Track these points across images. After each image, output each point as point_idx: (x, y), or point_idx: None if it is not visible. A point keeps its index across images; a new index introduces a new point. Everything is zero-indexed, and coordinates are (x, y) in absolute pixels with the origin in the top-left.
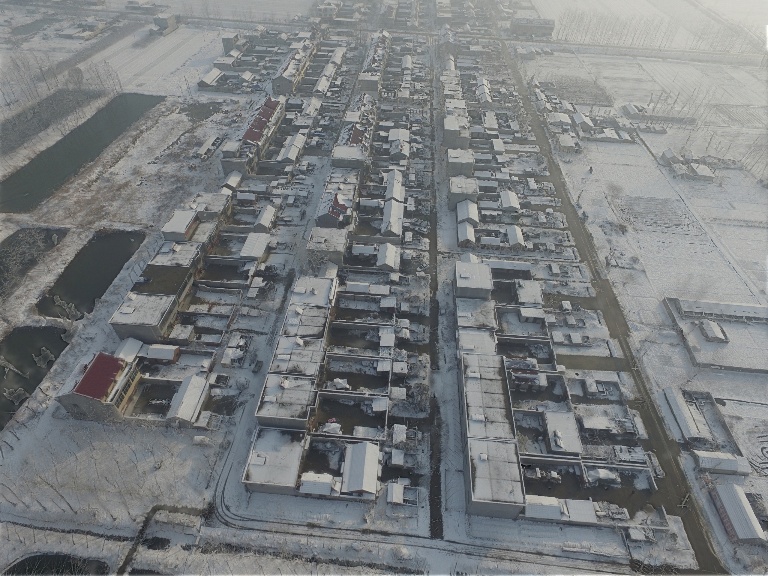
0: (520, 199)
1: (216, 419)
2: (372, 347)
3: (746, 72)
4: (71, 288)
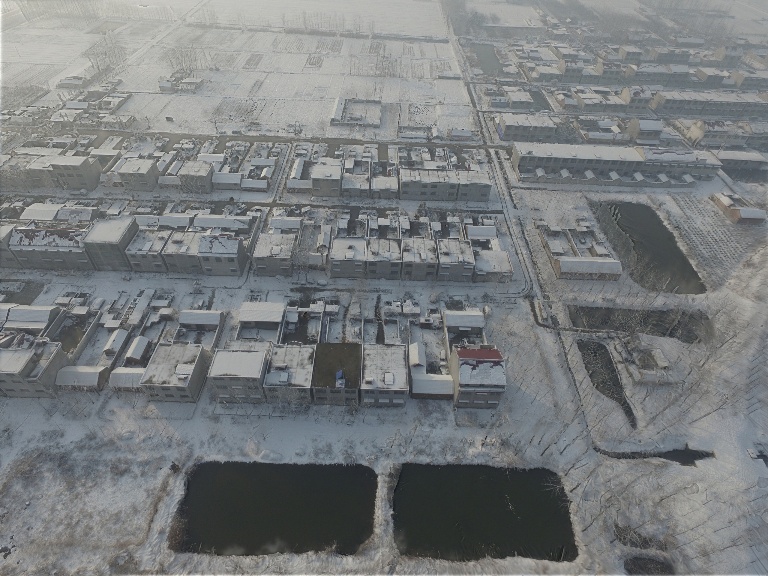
0: None
1: (470, 305)
2: (384, 235)
3: (30, 29)
4: (314, 523)
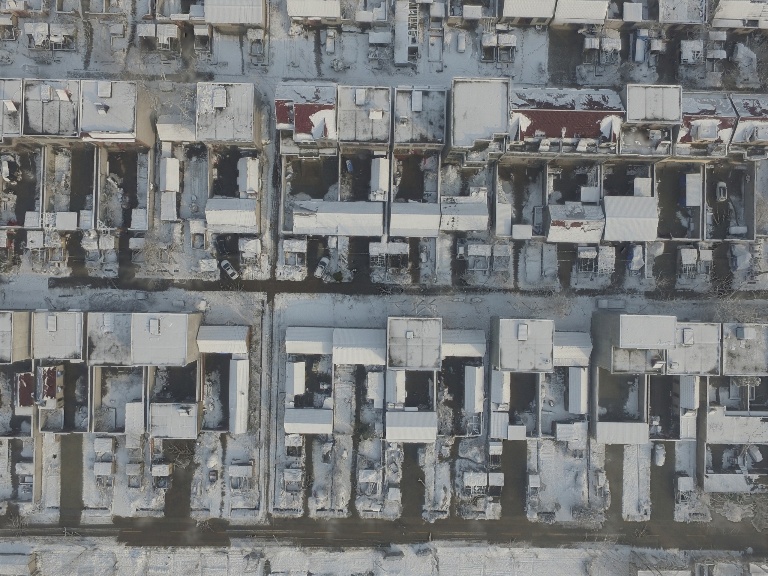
0: (438, 448)
1: None
2: (74, 204)
3: None
4: None
